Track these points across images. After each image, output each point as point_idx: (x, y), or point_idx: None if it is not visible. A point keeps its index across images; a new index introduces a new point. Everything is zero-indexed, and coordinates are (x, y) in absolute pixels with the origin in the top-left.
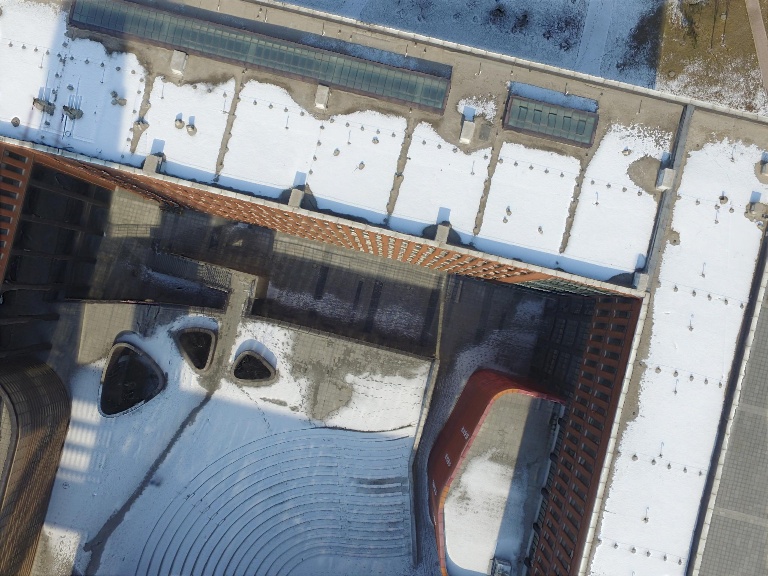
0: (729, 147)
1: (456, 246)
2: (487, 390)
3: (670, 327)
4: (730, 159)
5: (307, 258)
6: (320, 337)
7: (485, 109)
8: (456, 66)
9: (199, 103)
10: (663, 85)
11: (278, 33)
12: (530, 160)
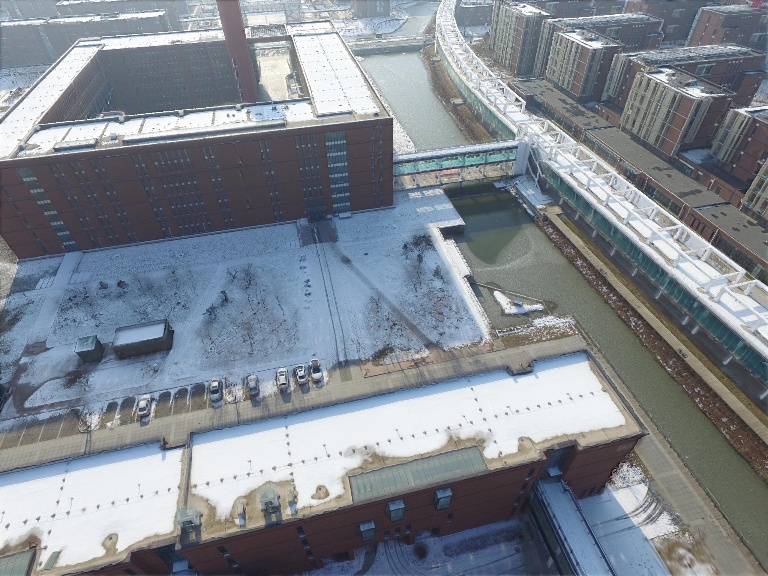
0: None
1: None
2: None
3: None
4: None
5: None
6: None
7: None
8: None
9: None
10: None
11: (201, 136)
12: None
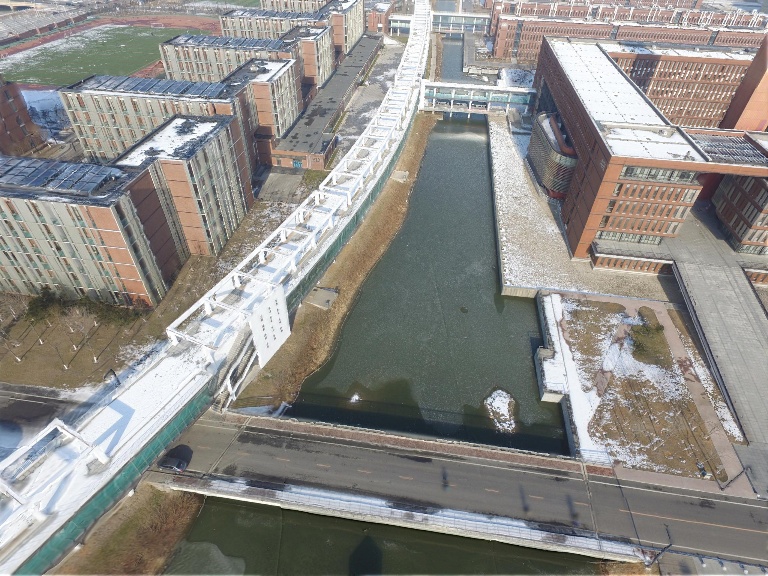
0: None
1: None
2: None
3: None
4: None
5: None
6: None
7: None
8: None
9: None
10: None
11: None
12: None
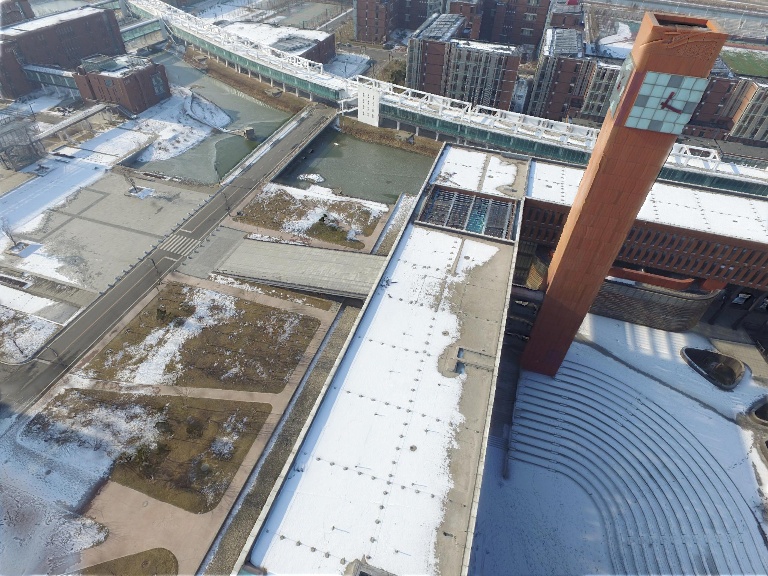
0: None
1: None
2: None
3: None
4: None
5: None
6: None
7: None
8: None
9: None
10: None
11: None
12: None
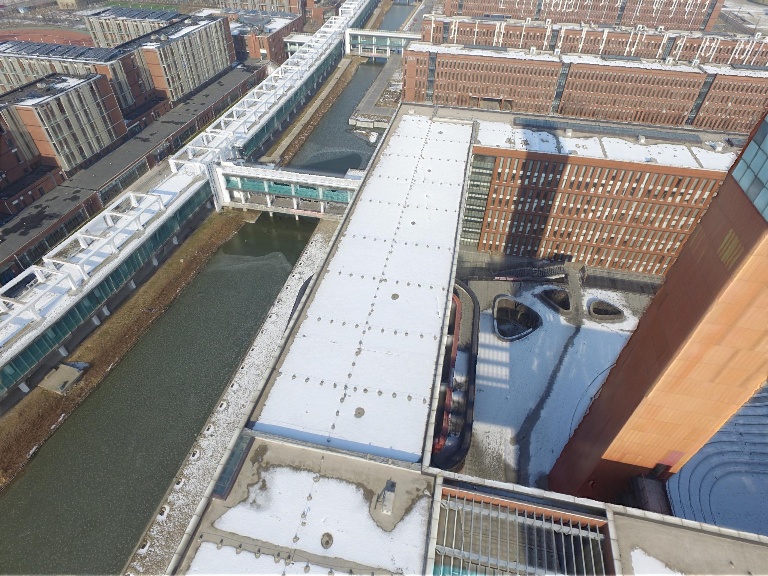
0: None
1: None
2: None
3: None
4: None
5: (597, 276)
6: (642, 296)
7: None
8: None
9: (584, 142)
10: None
11: None
12: None
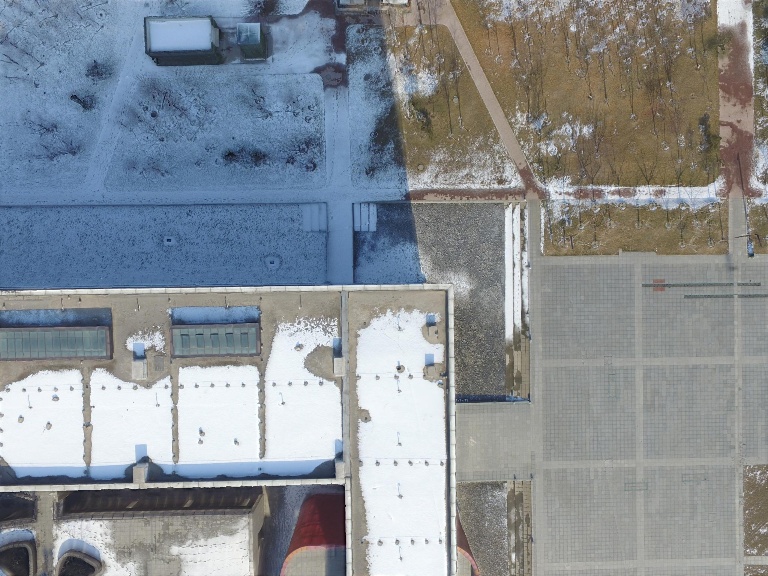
0: (394, 318)
1: (156, 483)
2: (290, 543)
3: (381, 500)
4: (397, 329)
5: None
6: (135, 519)
7: (153, 341)
8: (114, 307)
9: None
10: (415, 180)
11: None
12: (209, 379)
